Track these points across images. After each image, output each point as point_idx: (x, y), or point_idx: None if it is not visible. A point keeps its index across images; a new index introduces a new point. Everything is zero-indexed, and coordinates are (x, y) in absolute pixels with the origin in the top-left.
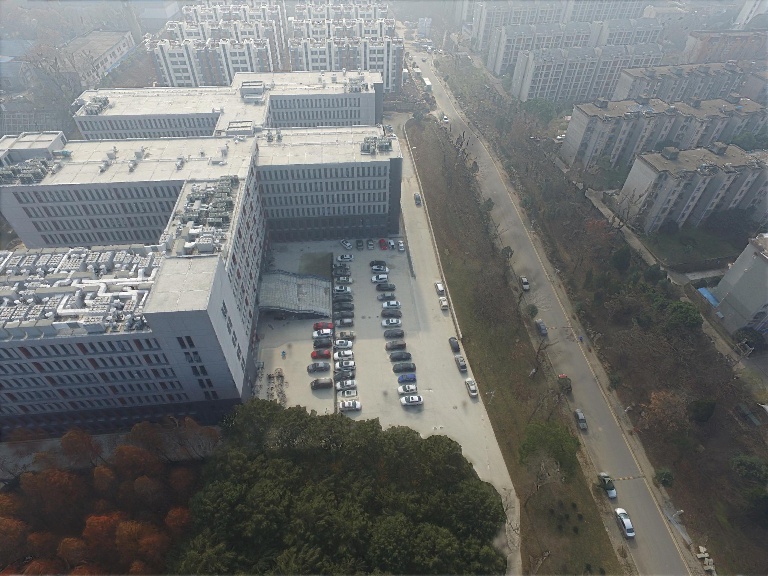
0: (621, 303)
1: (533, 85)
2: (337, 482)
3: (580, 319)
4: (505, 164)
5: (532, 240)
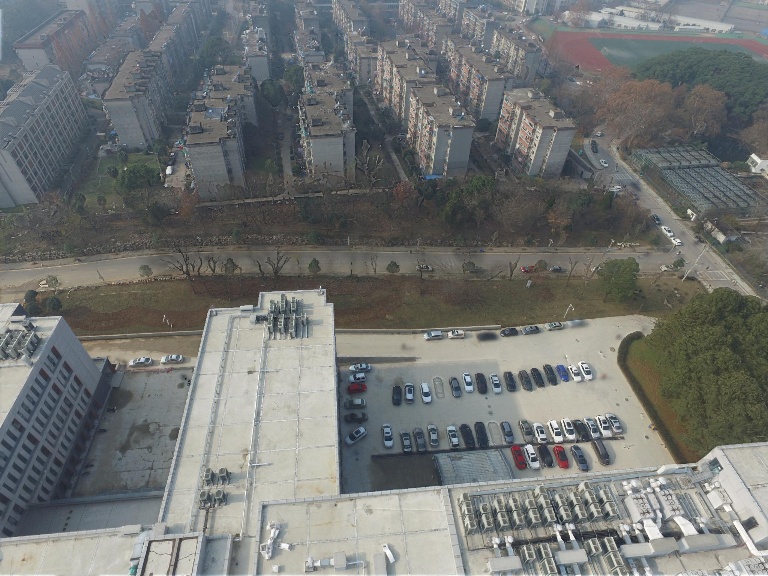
0: (467, 211)
1: (26, 177)
2: (767, 384)
3: (461, 246)
4: (236, 237)
5: (361, 251)
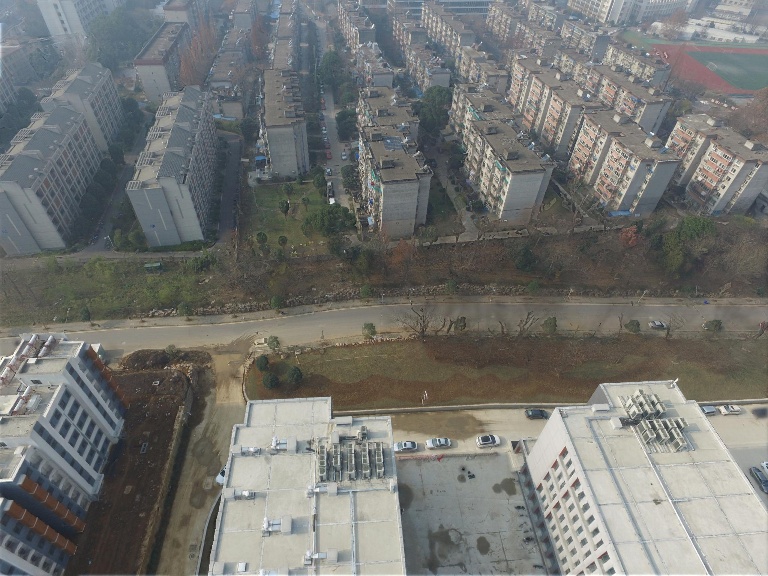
0: None
1: (196, 212)
2: None
3: (681, 297)
4: (454, 288)
5: (580, 303)
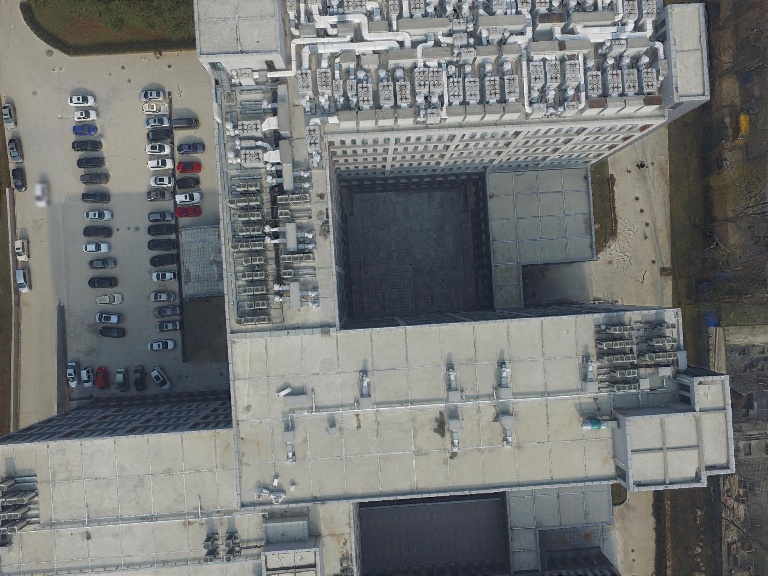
0: None
1: None
2: None
3: None
4: None
5: None
